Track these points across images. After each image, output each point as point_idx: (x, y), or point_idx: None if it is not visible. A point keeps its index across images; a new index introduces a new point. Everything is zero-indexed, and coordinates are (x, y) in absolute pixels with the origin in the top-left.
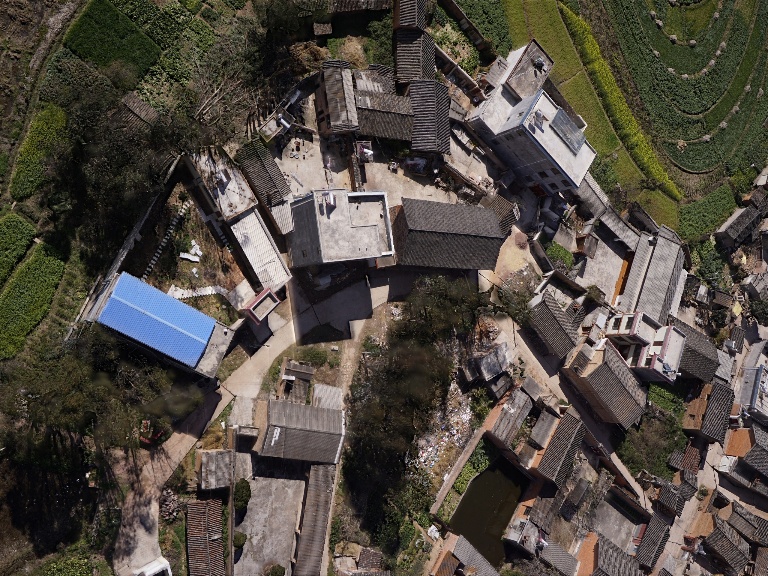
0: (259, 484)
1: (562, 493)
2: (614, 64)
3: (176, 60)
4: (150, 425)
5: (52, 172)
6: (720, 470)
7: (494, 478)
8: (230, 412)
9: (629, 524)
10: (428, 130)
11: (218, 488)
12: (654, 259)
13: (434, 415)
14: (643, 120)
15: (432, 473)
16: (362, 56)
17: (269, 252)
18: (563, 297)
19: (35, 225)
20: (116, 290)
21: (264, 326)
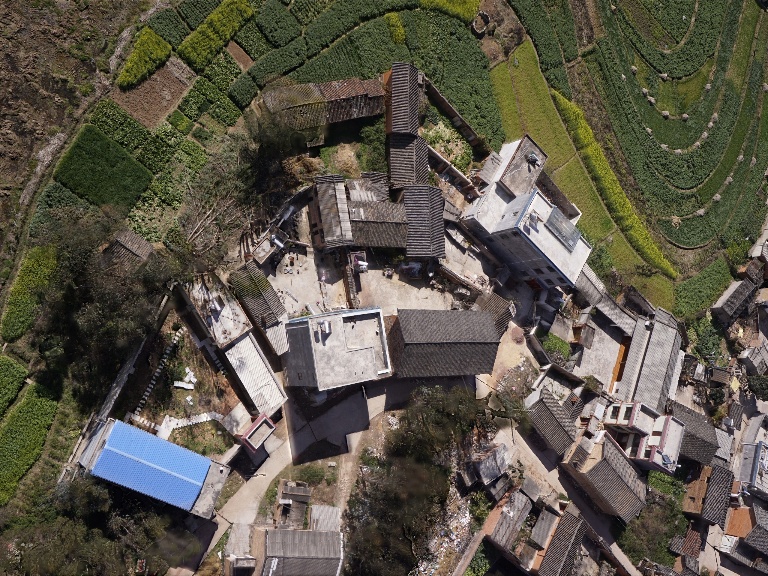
0: None
1: None
2: (607, 146)
3: (168, 184)
4: (146, 564)
5: (43, 322)
6: (721, 550)
7: None
8: (227, 541)
9: None
10: (422, 236)
11: None
12: (651, 345)
13: (433, 522)
14: (637, 200)
15: None
16: (355, 162)
17: (264, 375)
18: (561, 388)
19: (27, 365)
20: (109, 440)
21: (260, 449)
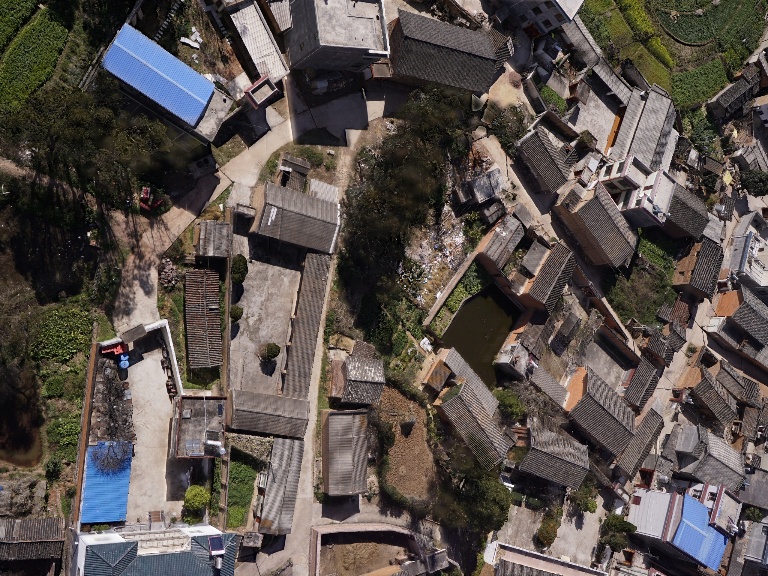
0: (256, 268)
1: (552, 323)
2: None
3: None
4: (150, 192)
5: None
6: (709, 331)
7: (486, 304)
8: (228, 196)
9: (618, 369)
10: None
11: (216, 264)
12: (646, 111)
13: (428, 234)
14: None
15: (425, 289)
16: None
17: (268, 45)
18: (556, 141)
19: None
20: (119, 38)
21: (262, 120)
